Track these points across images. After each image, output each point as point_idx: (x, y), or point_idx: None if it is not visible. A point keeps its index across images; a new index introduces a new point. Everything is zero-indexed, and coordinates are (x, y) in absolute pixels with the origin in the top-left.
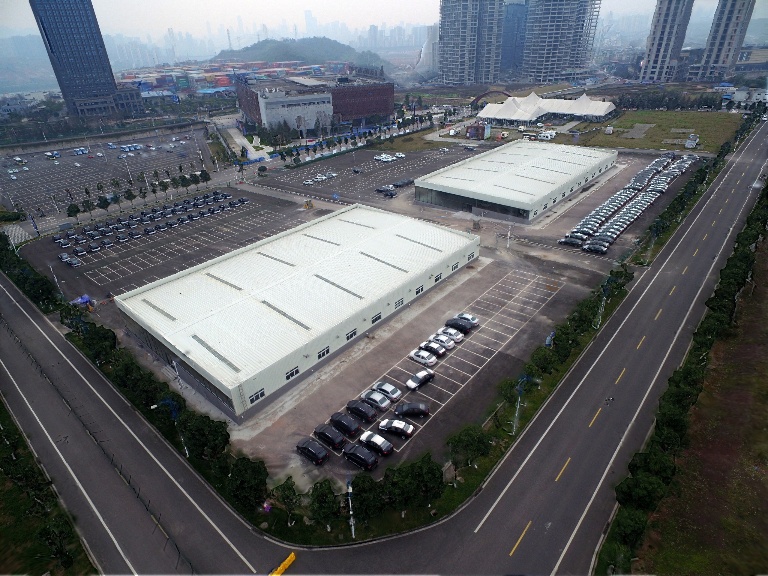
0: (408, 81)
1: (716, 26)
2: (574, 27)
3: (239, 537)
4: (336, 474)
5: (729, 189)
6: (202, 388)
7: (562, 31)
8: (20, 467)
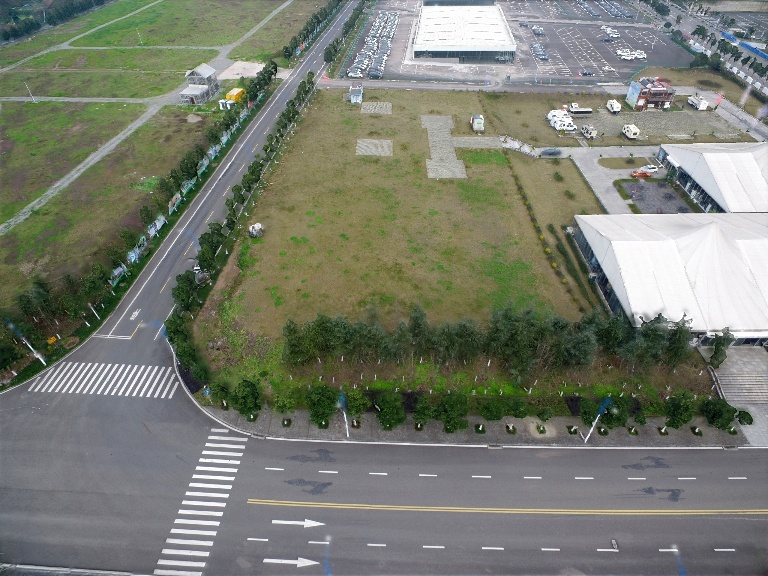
0: None
1: None
2: None
3: None
4: None
5: None
6: None
7: None
8: None
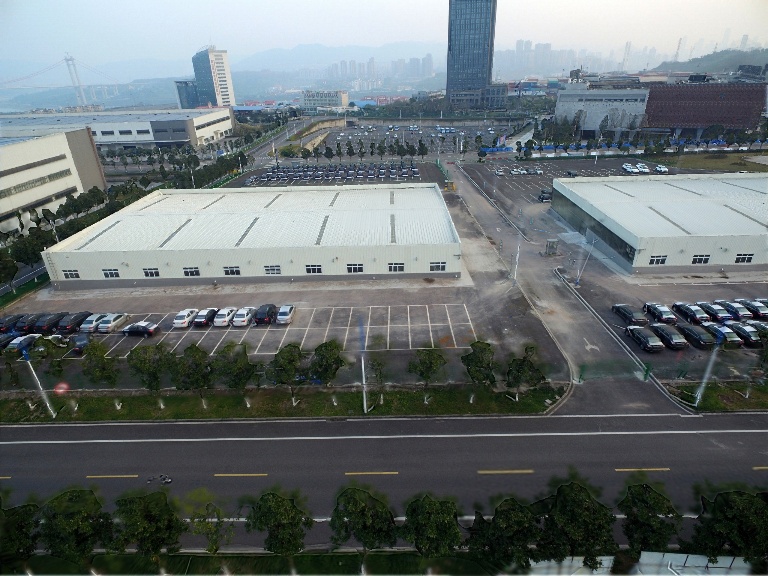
0: None
1: None
2: None
3: None
4: None
5: None
6: None
7: None
8: None
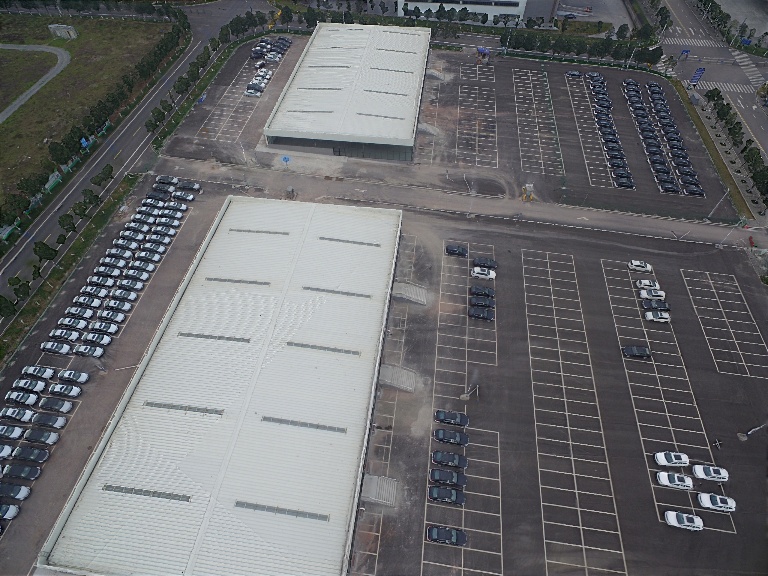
0: None
1: None
2: None
3: (289, 27)
4: None
5: None
6: None
7: None
8: (356, 2)
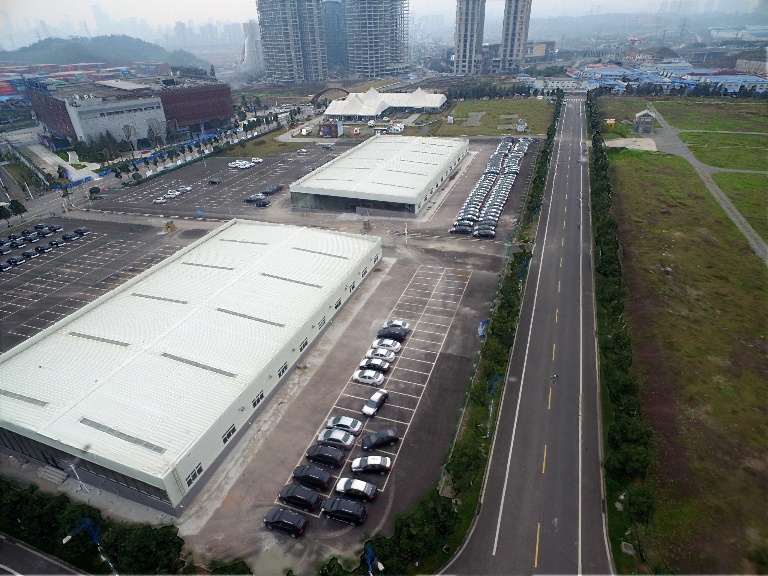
0: (237, 81)
1: (507, 24)
2: (390, 25)
3: None
4: (323, 541)
5: (565, 165)
6: (112, 485)
7: (380, 28)
8: None
